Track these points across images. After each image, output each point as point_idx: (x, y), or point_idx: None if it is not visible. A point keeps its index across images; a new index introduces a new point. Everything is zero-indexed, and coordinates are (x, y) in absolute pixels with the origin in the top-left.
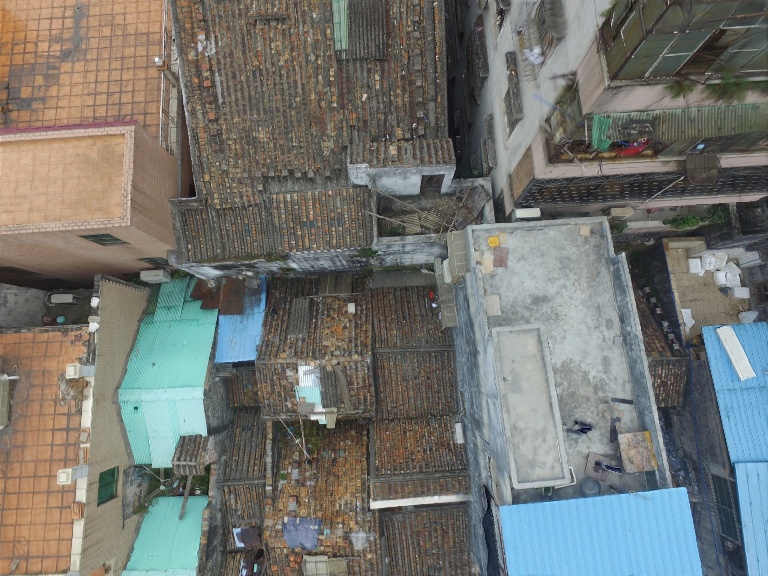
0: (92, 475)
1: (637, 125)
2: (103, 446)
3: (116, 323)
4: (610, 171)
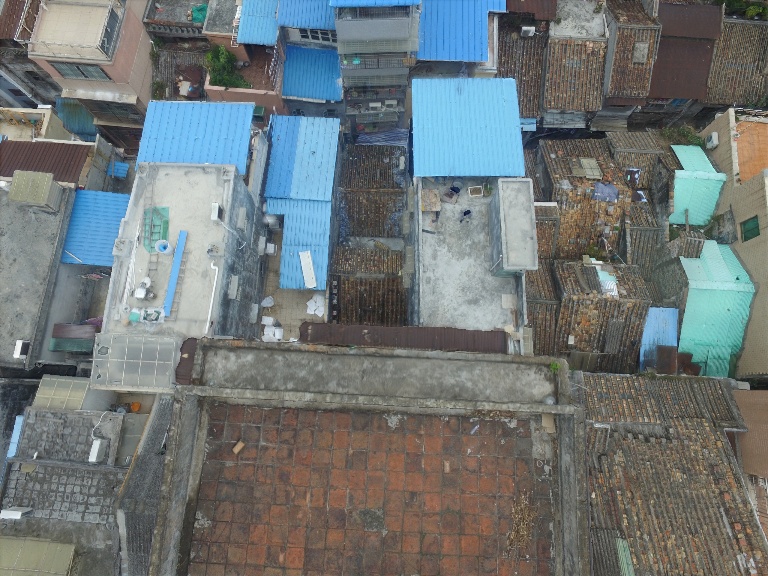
0: (767, 233)
1: None
2: (761, 252)
3: (767, 341)
4: None
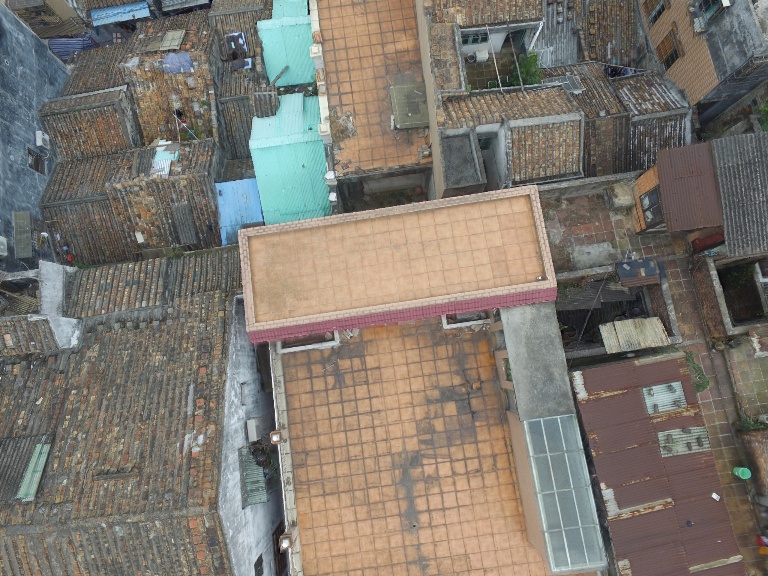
0: None
1: None
2: None
3: None
4: None
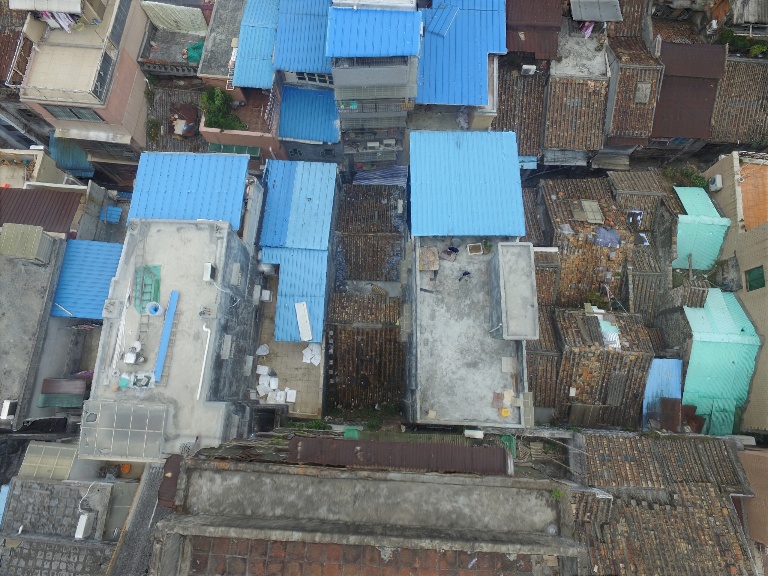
0: None
1: None
2: (766, 305)
3: None
4: None
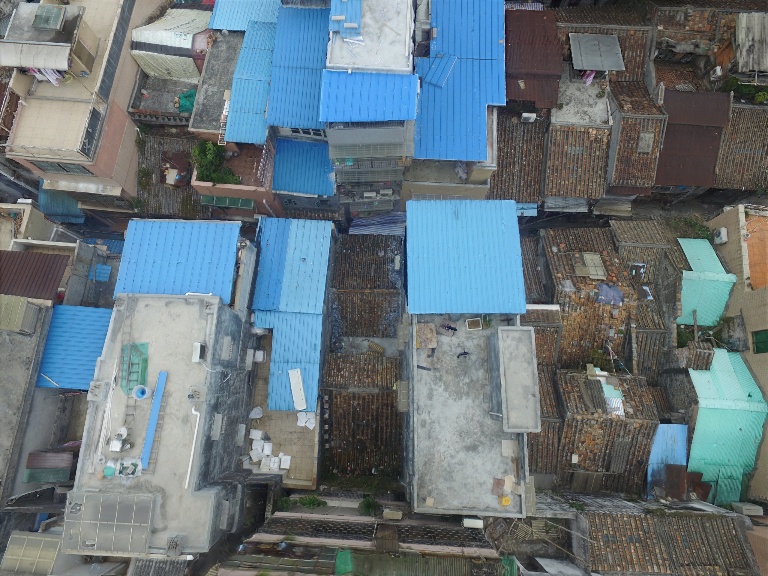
0: None
1: (482, 575)
2: None
3: None
4: (440, 548)
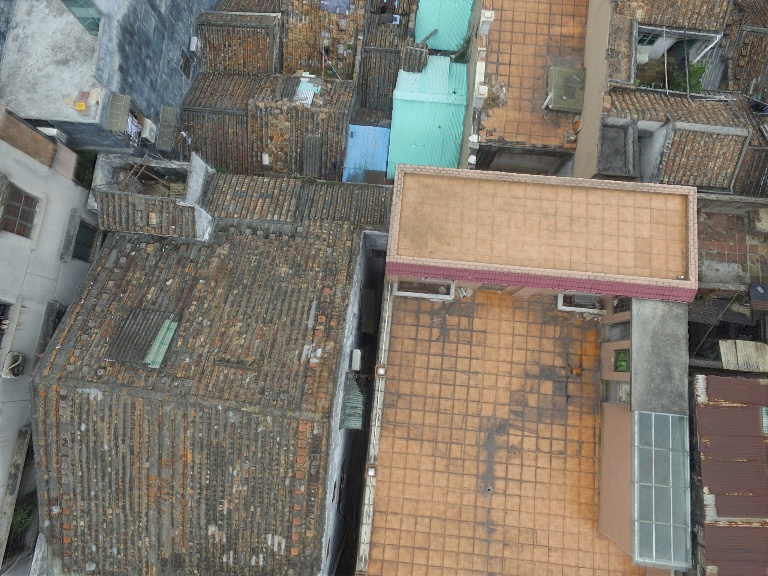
0: None
1: None
2: None
3: None
4: None
